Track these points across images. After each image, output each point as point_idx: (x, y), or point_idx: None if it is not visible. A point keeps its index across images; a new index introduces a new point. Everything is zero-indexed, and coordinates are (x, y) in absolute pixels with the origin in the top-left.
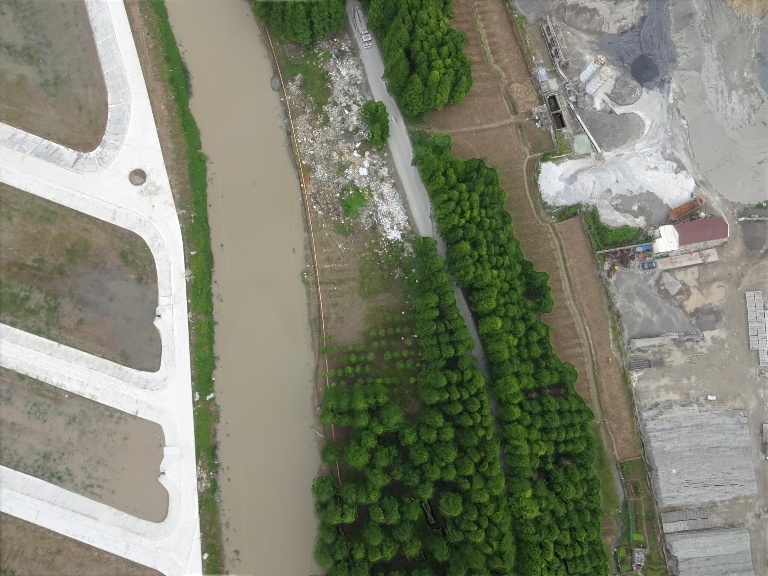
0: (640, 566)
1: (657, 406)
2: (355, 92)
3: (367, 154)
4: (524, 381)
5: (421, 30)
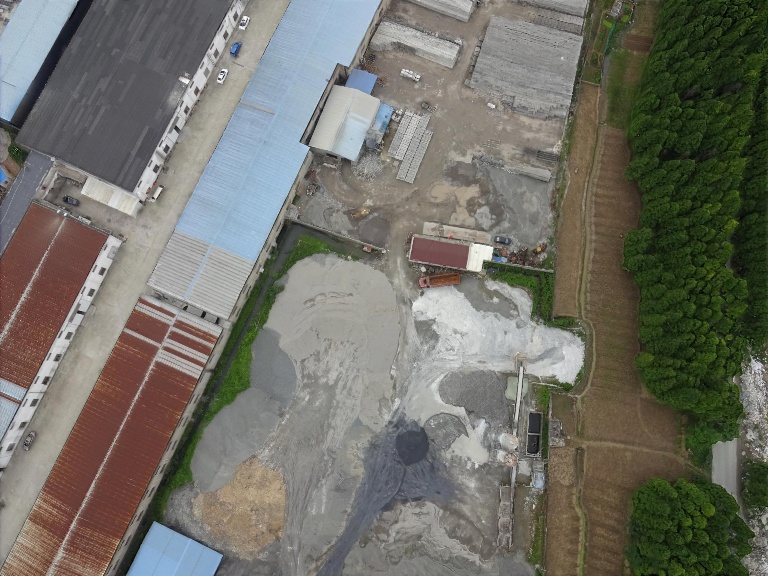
0: (618, 2)
1: (549, 116)
2: (759, 538)
3: (765, 461)
4: (724, 164)
5: (721, 568)
